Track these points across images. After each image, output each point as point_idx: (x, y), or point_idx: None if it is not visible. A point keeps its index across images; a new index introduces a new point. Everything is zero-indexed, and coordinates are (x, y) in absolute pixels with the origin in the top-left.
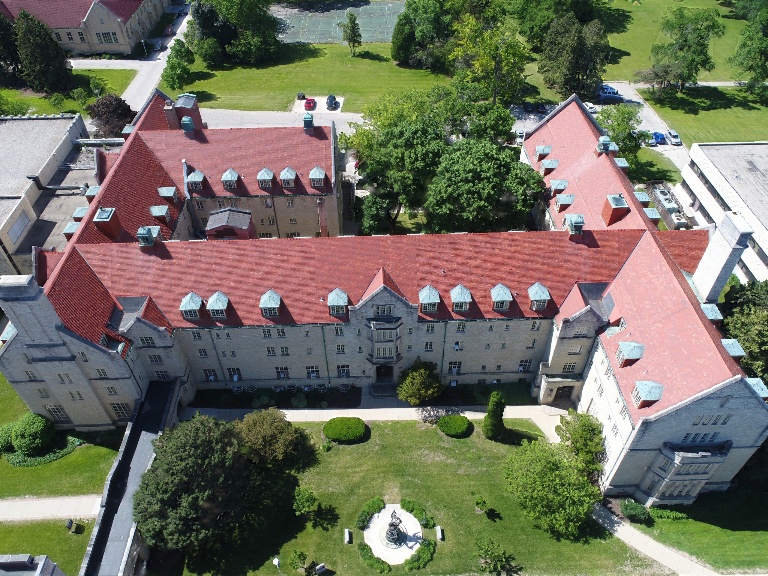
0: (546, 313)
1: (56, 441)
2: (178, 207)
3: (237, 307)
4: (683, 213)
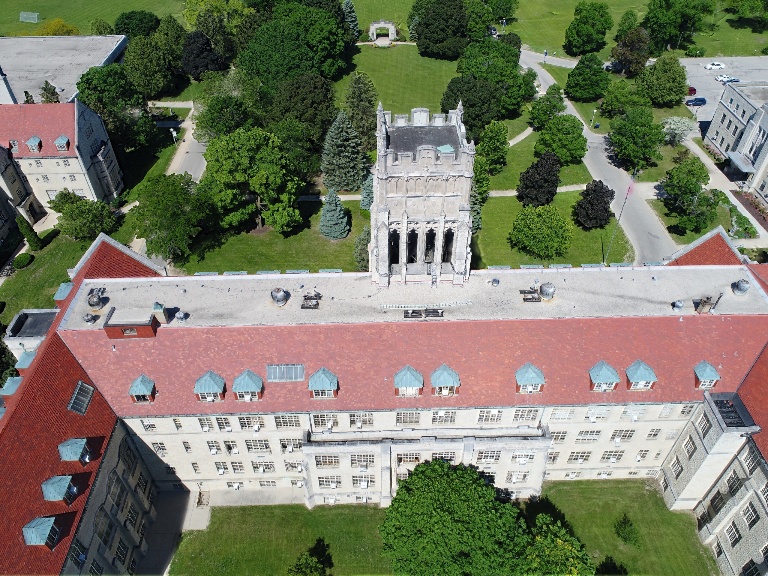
0: None
1: None
2: None
3: None
4: None
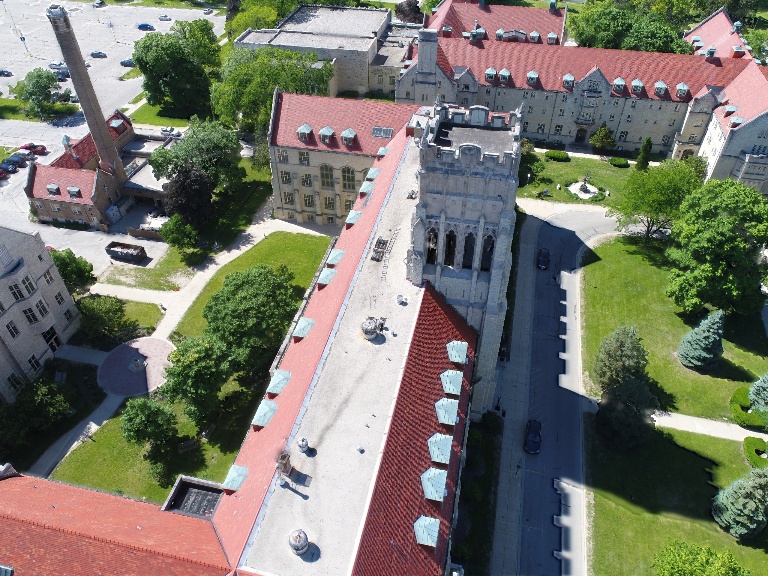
0: (685, 99)
1: None
2: None
3: (514, 77)
4: None
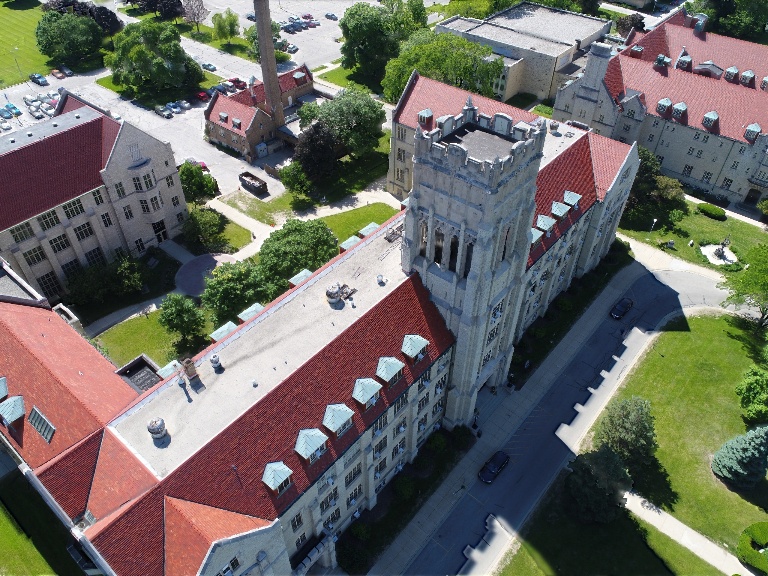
0: None
1: None
2: None
3: (689, 114)
4: None
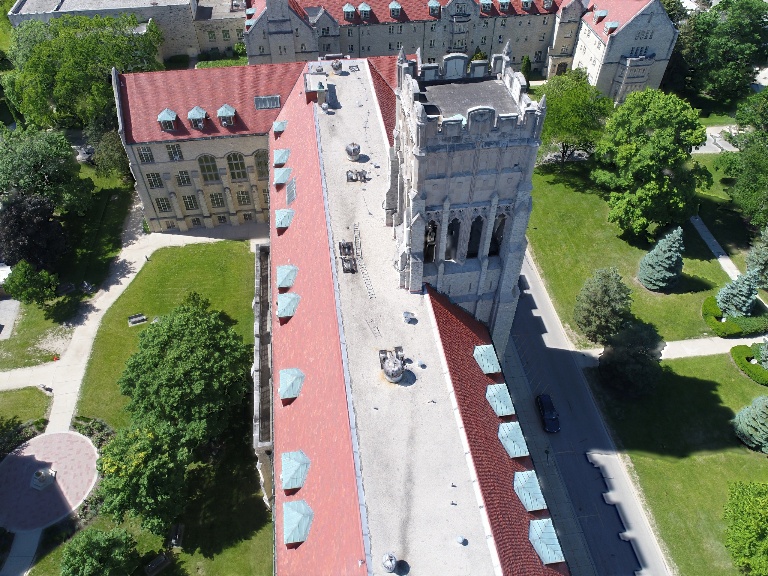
0: (551, 10)
1: None
2: None
3: (375, 11)
4: None
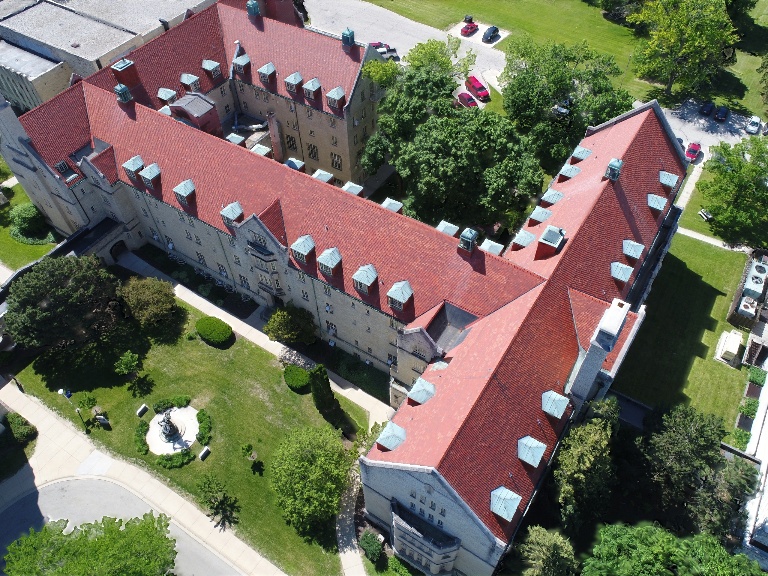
0: (401, 316)
1: (42, 232)
2: (215, 83)
3: (163, 183)
4: (763, 303)
